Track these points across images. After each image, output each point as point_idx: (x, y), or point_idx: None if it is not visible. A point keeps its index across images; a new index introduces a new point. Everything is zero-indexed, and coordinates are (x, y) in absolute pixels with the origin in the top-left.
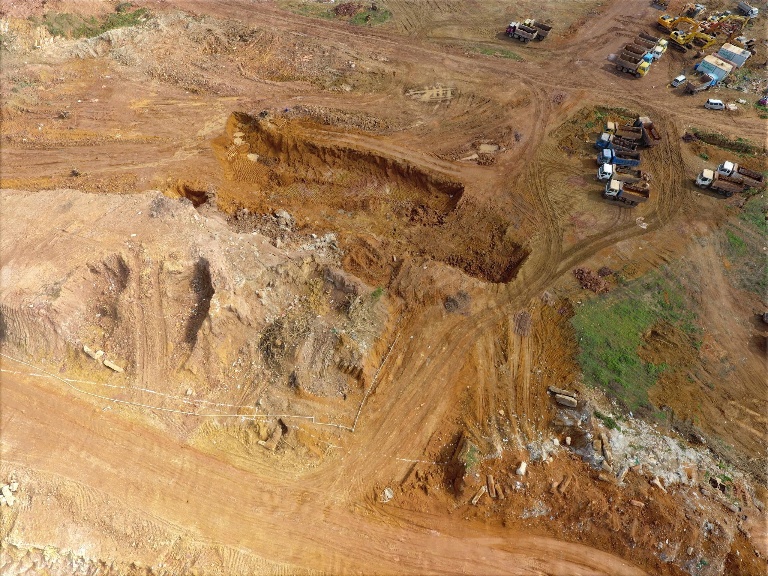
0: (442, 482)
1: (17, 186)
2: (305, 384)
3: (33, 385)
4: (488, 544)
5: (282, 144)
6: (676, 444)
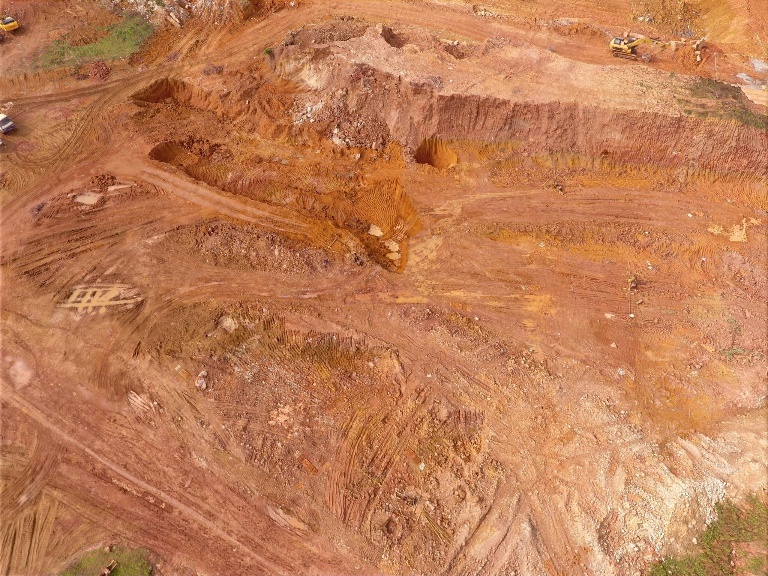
0: (263, 6)
1: (610, 177)
2: None
3: None
4: None
5: None
6: None
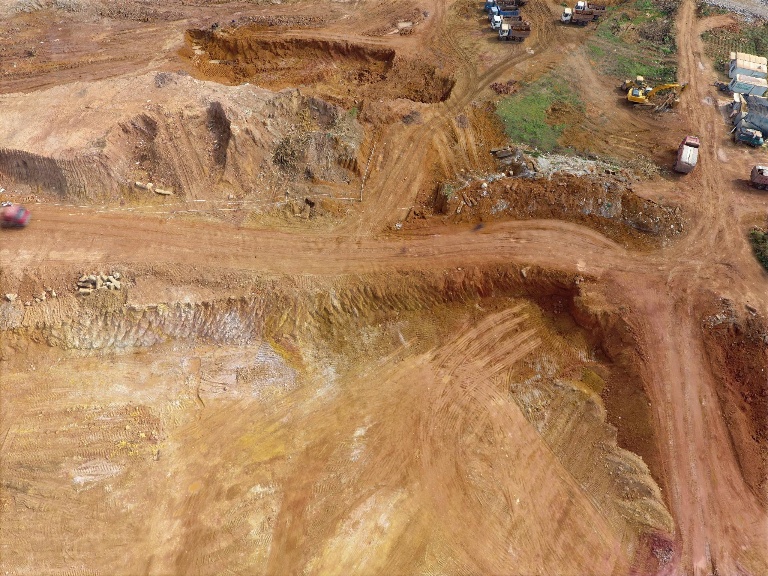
0: (433, 213)
1: None
2: (318, 174)
3: (102, 217)
4: (474, 233)
5: (238, 46)
6: (580, 159)
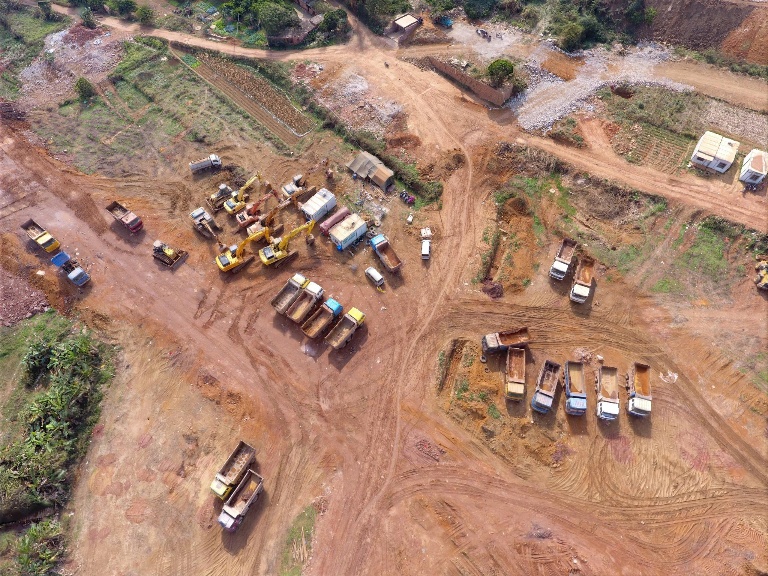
0: None
1: None
2: None
3: None
4: None
5: None
6: None
